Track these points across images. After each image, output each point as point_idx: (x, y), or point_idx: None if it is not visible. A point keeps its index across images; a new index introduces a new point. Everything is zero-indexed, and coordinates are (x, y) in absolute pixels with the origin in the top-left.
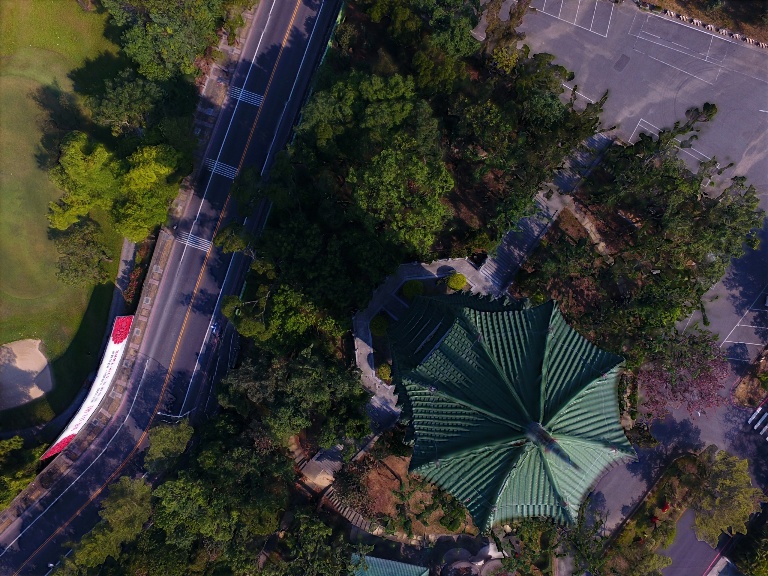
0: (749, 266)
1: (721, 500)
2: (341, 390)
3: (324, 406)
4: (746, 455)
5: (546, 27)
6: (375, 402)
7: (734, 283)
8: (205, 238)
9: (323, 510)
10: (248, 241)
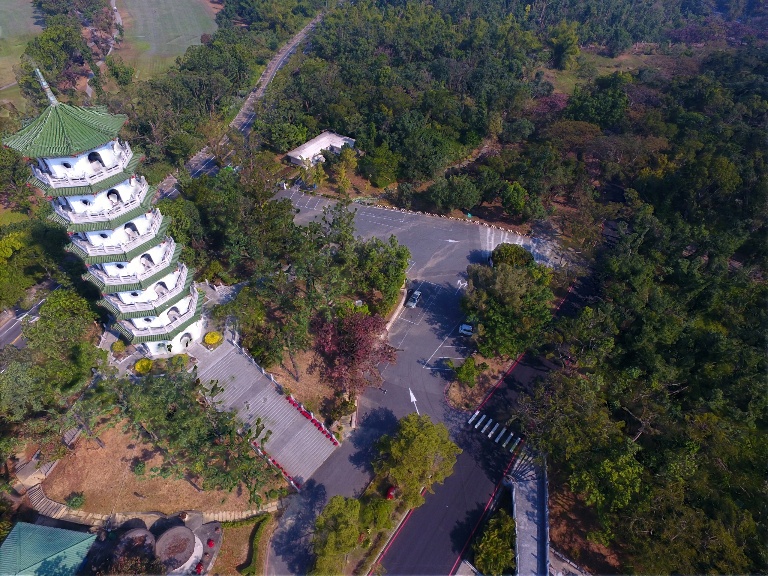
0: (443, 311)
1: (407, 443)
2: (63, 324)
3: (52, 361)
4: (471, 451)
5: (306, 212)
6: (104, 375)
7: (434, 321)
8: (36, 316)
9: (17, 512)
10: (44, 250)
